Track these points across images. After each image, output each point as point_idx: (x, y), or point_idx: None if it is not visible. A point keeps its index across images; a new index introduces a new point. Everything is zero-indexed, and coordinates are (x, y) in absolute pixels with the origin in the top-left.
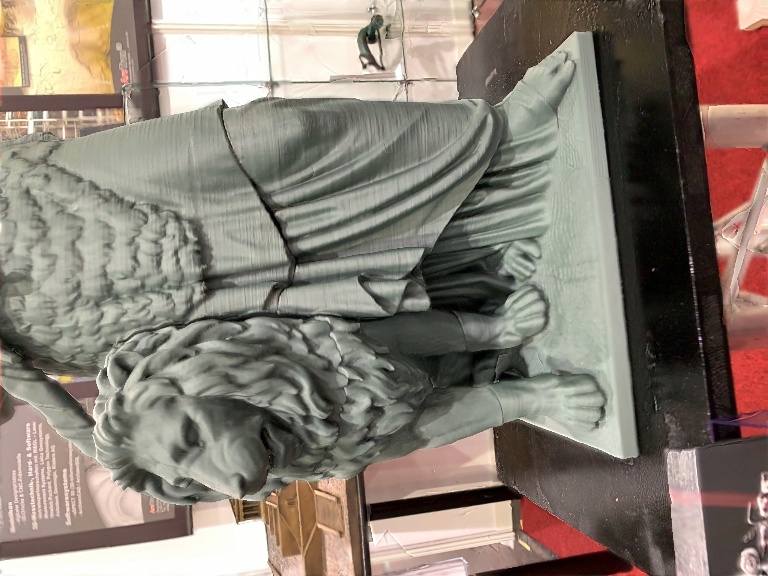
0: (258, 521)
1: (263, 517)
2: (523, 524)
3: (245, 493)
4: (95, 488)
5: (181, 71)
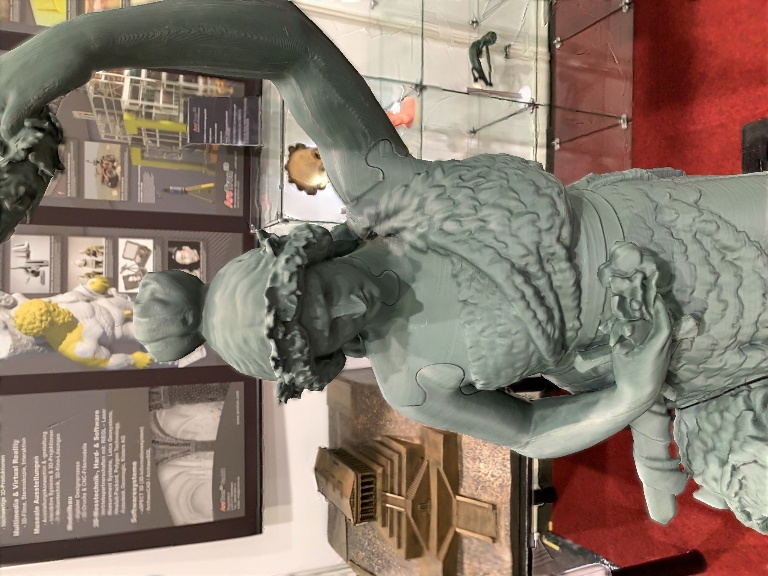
0: (313, 520)
1: (380, 519)
2: (553, 526)
3: None
4: (166, 483)
5: None
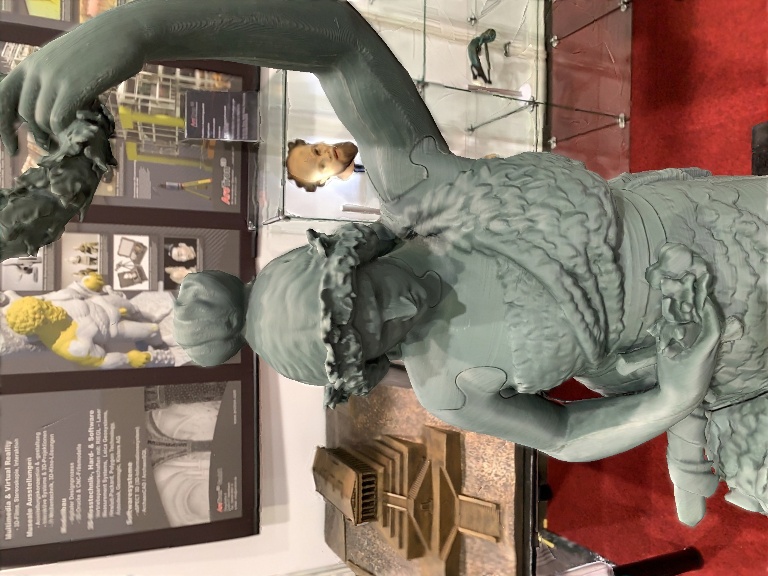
0: (310, 519)
1: (381, 519)
2: (548, 523)
3: None
4: (162, 484)
5: None
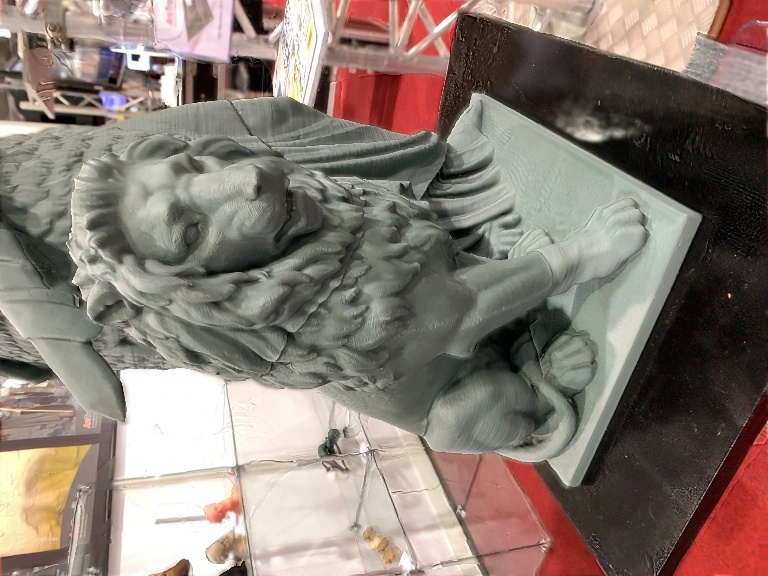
0: None
1: None
2: None
3: (262, 178)
4: None
5: (145, 465)
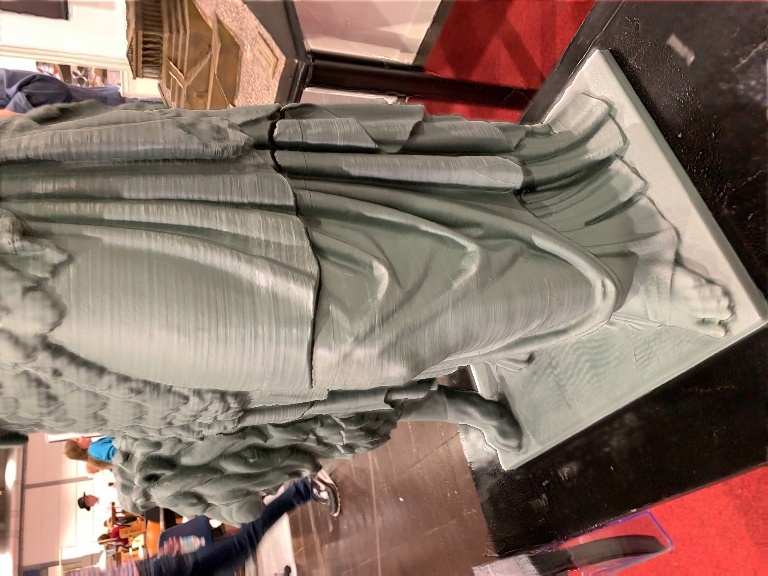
0: None
1: (164, 81)
2: (409, 101)
3: None
4: None
5: None
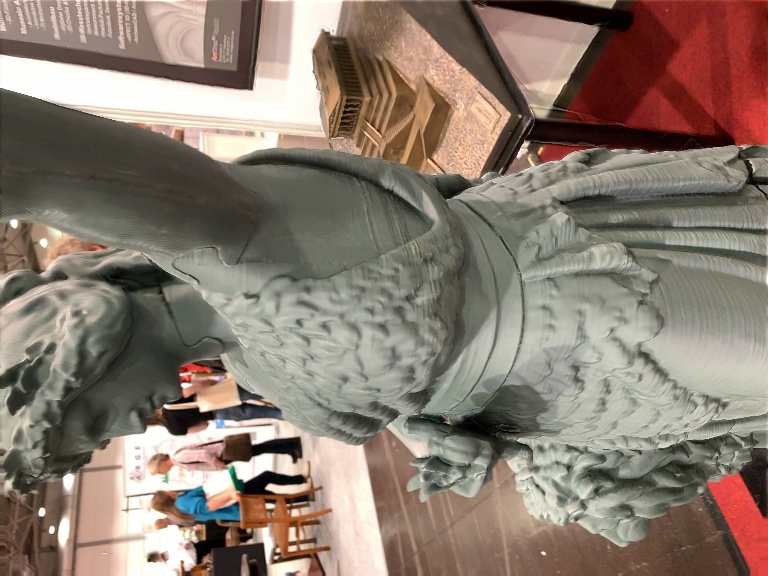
0: (310, 82)
1: (356, 140)
2: (542, 152)
3: None
4: (153, 19)
5: None
